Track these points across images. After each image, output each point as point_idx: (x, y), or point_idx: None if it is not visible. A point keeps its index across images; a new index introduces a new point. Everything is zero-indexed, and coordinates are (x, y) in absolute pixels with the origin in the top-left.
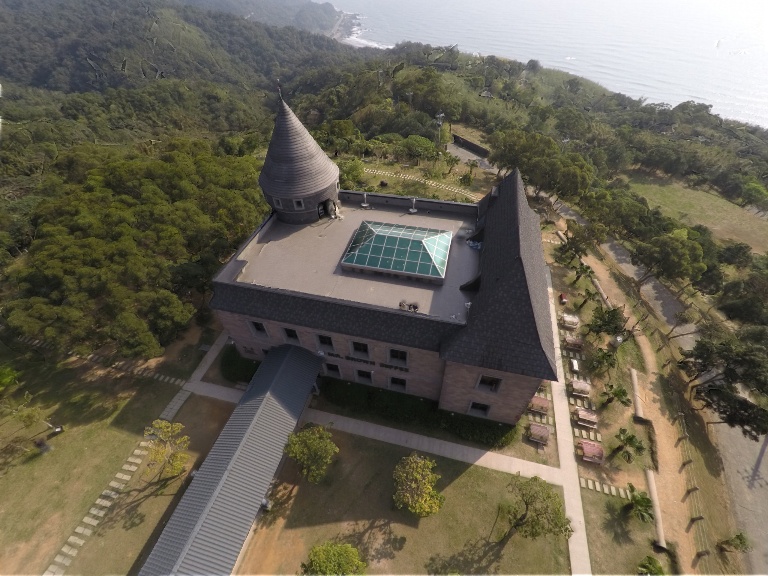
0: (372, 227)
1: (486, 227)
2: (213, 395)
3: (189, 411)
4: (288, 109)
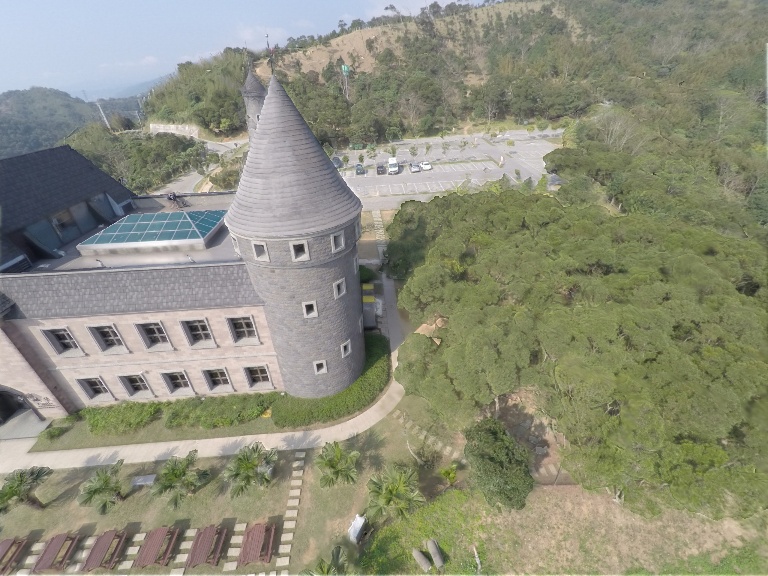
0: (190, 227)
1: (35, 218)
2: (362, 260)
3: (372, 253)
4: (270, 92)
